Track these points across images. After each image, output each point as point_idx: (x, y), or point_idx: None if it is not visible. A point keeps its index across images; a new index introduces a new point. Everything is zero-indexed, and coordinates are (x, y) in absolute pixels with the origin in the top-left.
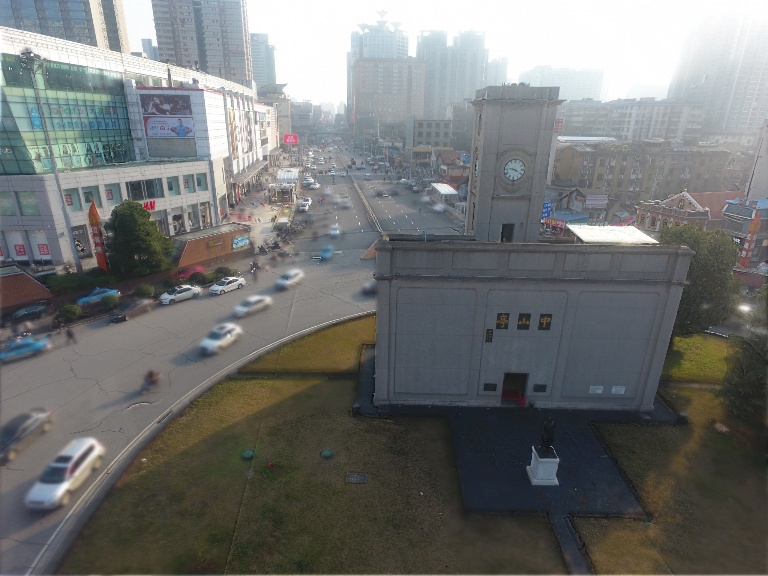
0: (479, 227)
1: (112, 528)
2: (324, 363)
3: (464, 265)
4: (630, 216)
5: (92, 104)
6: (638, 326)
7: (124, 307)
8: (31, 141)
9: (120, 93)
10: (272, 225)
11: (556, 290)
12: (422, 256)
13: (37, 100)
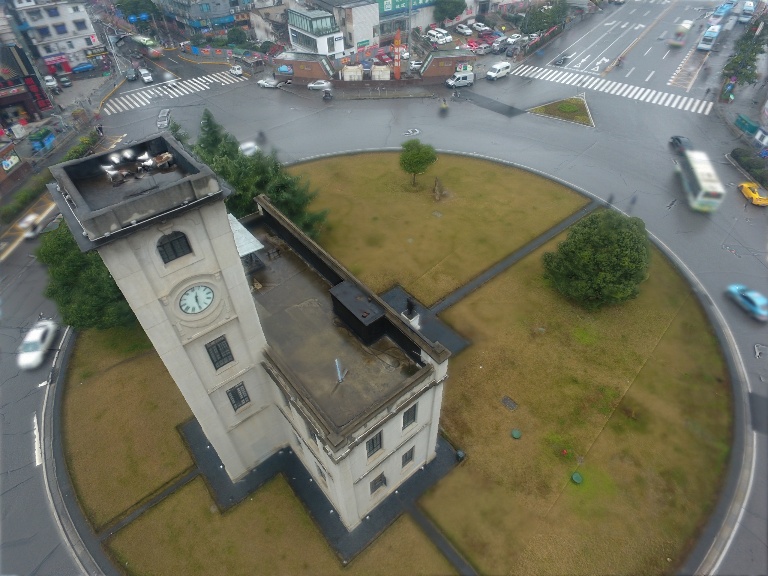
0: None
1: (690, 494)
2: (423, 566)
3: None
4: None
5: None
6: None
7: None
8: None
9: None
10: None
11: None
12: None
13: None
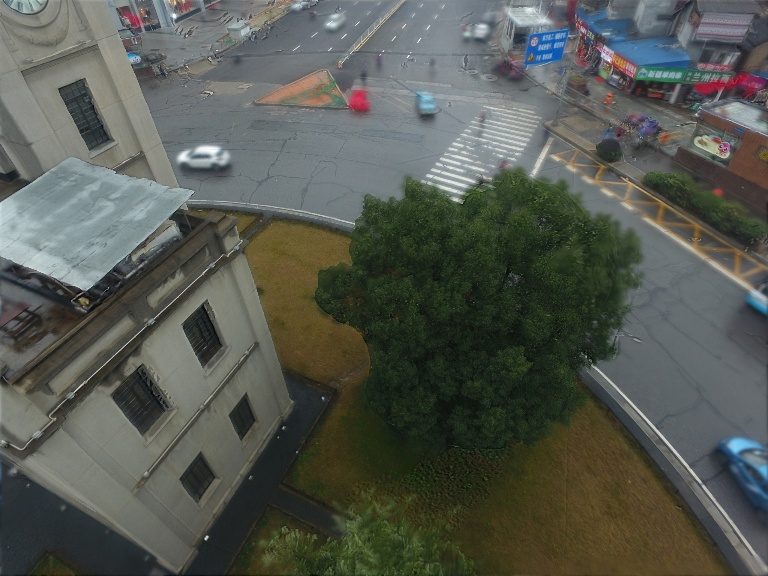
0: None
1: None
2: None
3: None
4: None
5: None
6: None
7: None
8: None
9: None
10: None
11: None
12: None
13: None
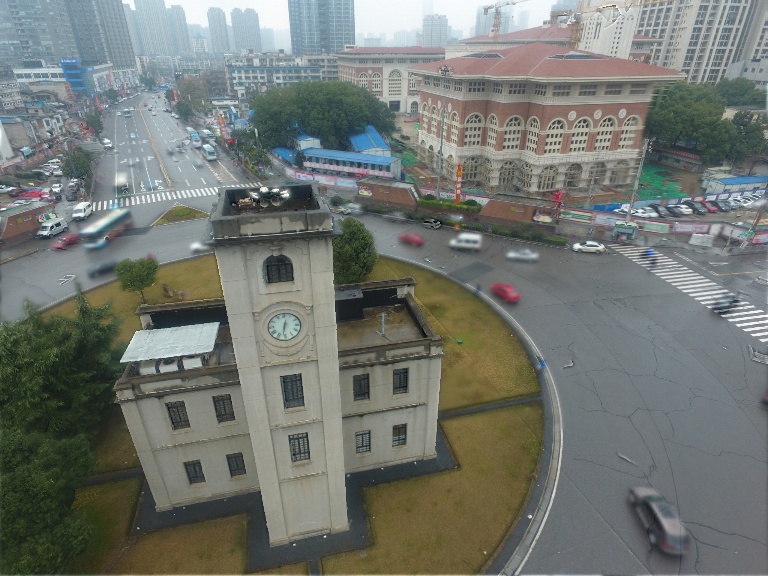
0: None
1: None
2: (477, 425)
3: None
4: None
5: None
6: None
7: None
8: None
9: None
10: None
11: None
12: None
13: None
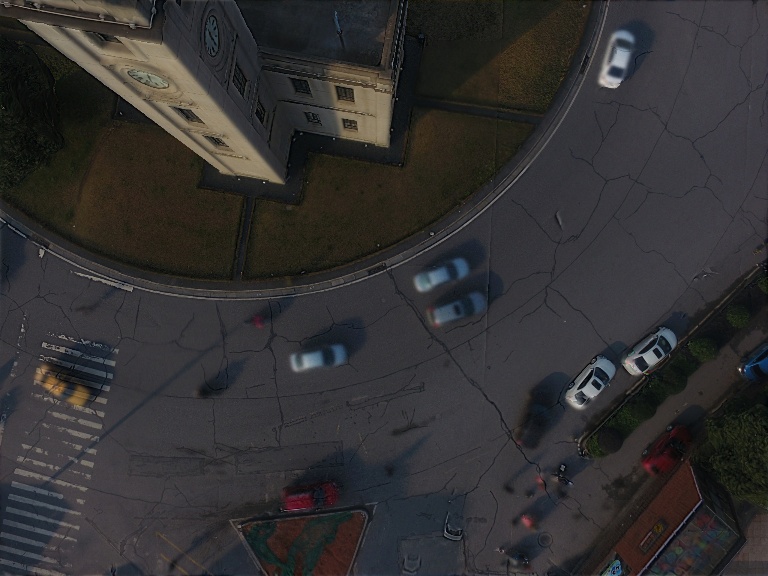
0: None
1: None
2: (448, 128)
3: None
4: None
5: None
6: None
7: None
8: None
9: None
10: None
11: None
12: None
13: None
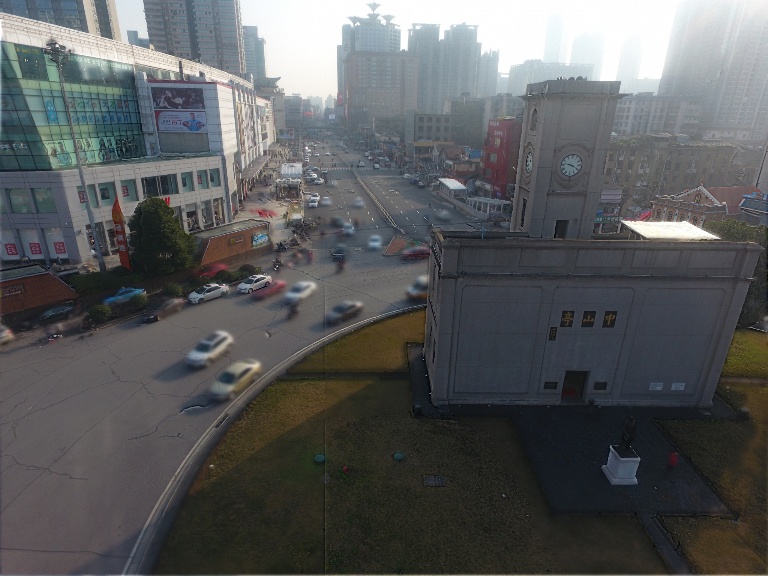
0: (533, 223)
1: (196, 538)
2: (372, 363)
3: (531, 263)
4: (642, 211)
5: (105, 97)
6: (702, 322)
7: (153, 307)
8: (47, 136)
9: (131, 86)
10: (285, 221)
11: (623, 287)
12: (489, 254)
13: (52, 93)
